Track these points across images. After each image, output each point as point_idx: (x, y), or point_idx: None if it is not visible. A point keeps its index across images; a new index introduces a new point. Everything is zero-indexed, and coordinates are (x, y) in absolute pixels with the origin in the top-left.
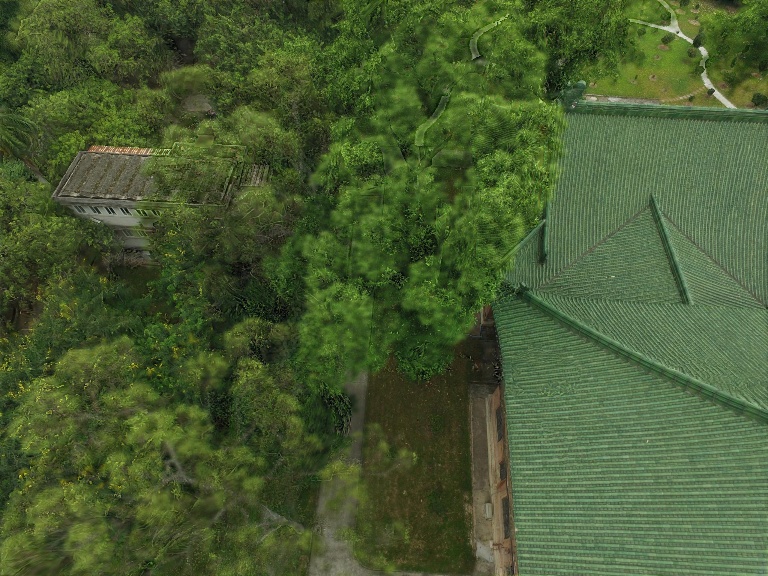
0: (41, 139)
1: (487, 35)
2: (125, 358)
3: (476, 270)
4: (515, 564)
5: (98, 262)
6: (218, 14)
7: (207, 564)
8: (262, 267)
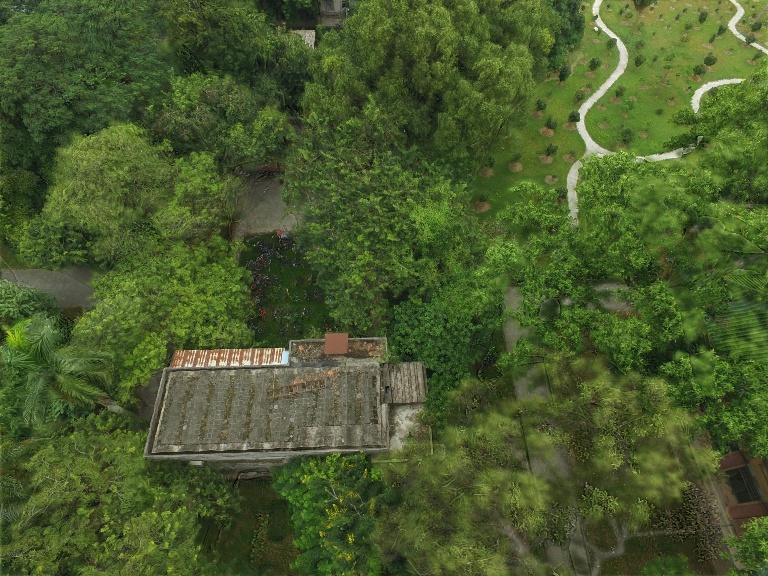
0: (112, 361)
1: (593, 113)
2: None
3: None
4: None
5: (210, 529)
6: (316, 148)
7: None
8: (450, 531)
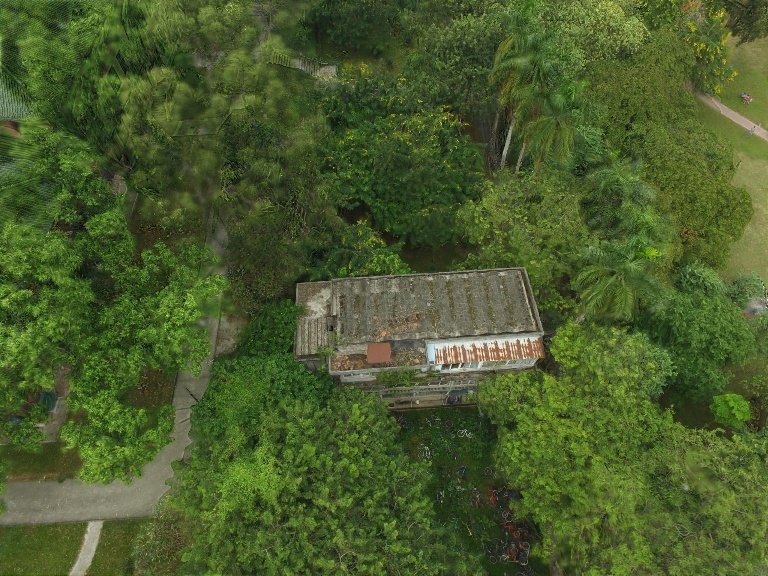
0: None
1: None
2: (366, 151)
3: None
4: (122, 104)
5: None
6: None
7: None
8: None
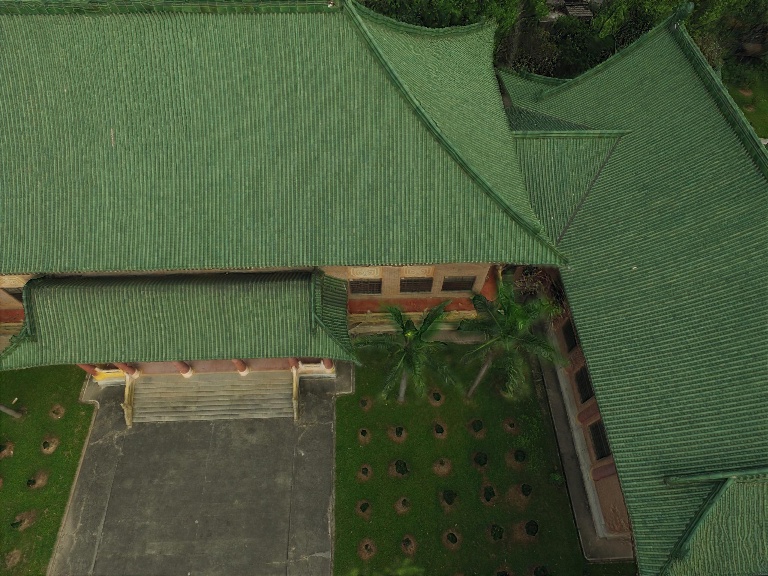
0: None
1: None
2: None
3: None
4: None
5: None
6: None
7: None
8: None
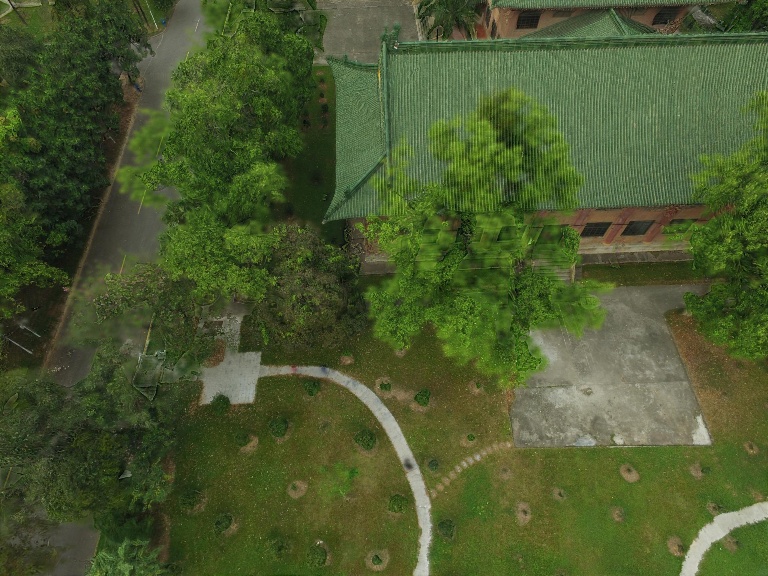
0: None
1: None
2: None
3: None
4: None
5: None
6: None
7: None
8: None
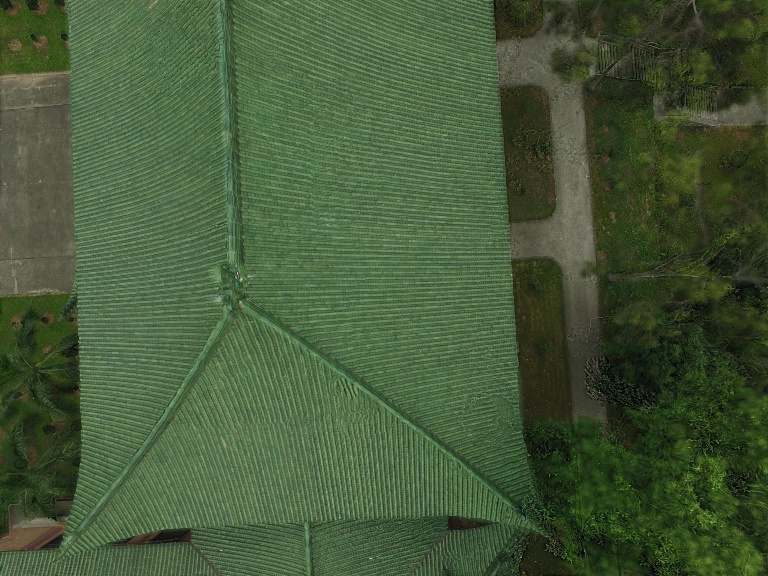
0: None
1: None
2: None
3: (569, 535)
4: None
5: None
6: None
7: (667, 247)
8: None
